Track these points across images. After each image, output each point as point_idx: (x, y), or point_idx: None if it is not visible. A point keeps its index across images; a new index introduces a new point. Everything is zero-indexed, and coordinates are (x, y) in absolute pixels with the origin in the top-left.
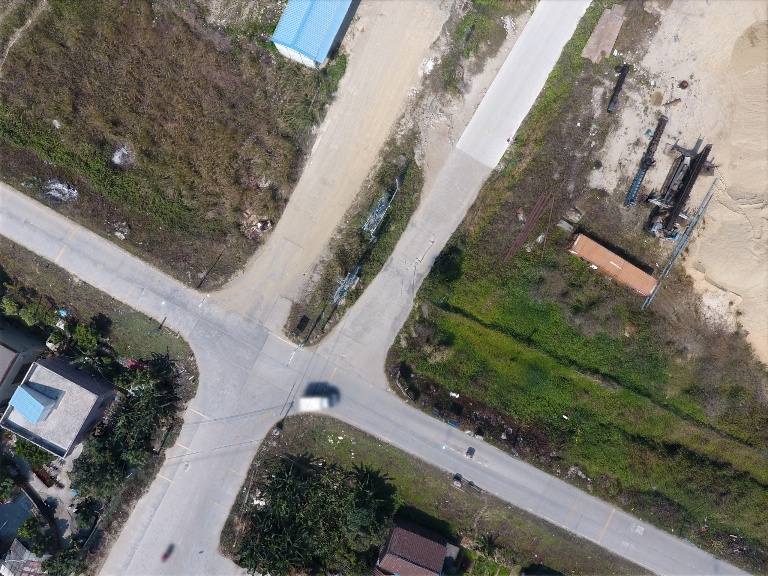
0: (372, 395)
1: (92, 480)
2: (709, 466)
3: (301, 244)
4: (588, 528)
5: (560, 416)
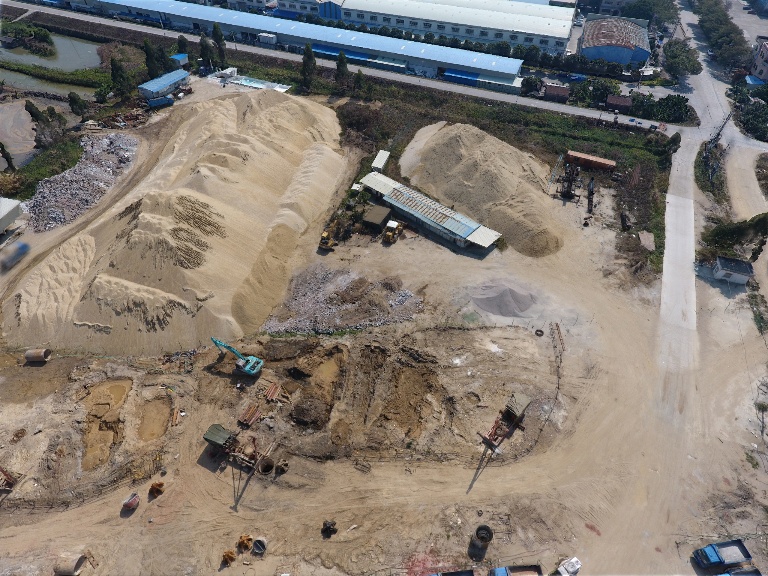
0: (668, 131)
1: (760, 106)
2: (507, 121)
3: (738, 169)
4: (554, 105)
5: (580, 131)
